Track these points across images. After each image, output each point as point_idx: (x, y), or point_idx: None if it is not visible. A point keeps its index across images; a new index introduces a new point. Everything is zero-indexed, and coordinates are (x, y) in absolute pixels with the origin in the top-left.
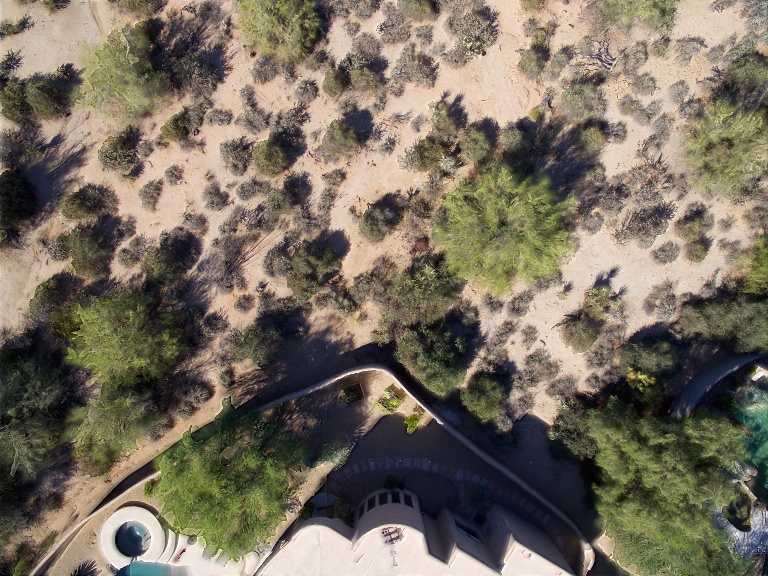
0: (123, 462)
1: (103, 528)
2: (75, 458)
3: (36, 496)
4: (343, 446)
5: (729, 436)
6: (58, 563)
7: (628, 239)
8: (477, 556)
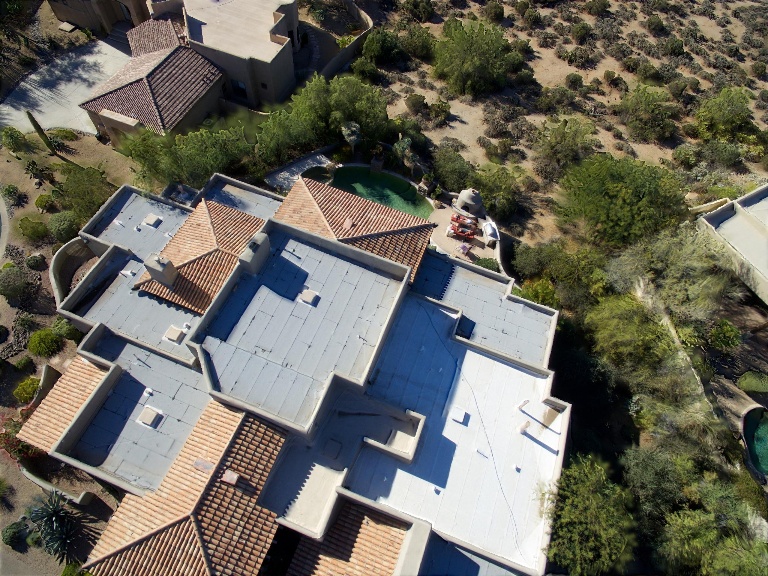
0: None
1: None
2: None
3: None
4: None
5: None
6: None
7: None
8: None
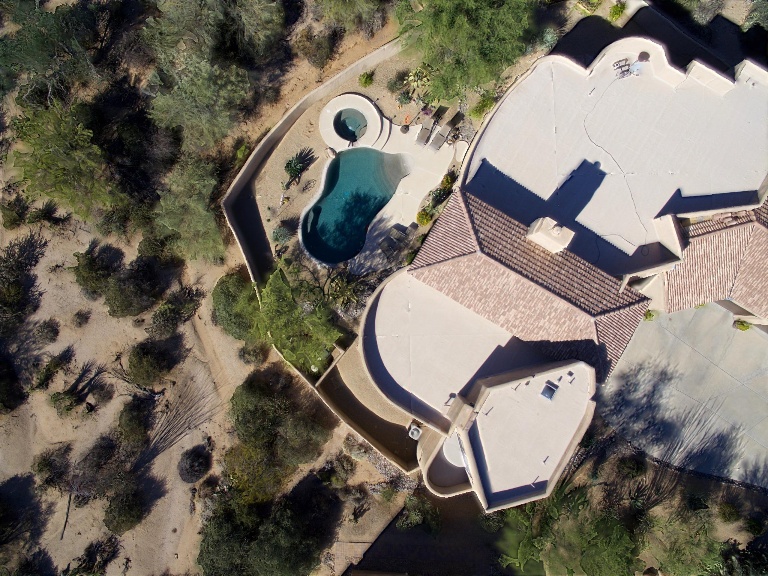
0: (334, 61)
1: (321, 113)
2: (293, 48)
3: (252, 91)
4: None
5: None
6: (275, 152)
7: None
8: None
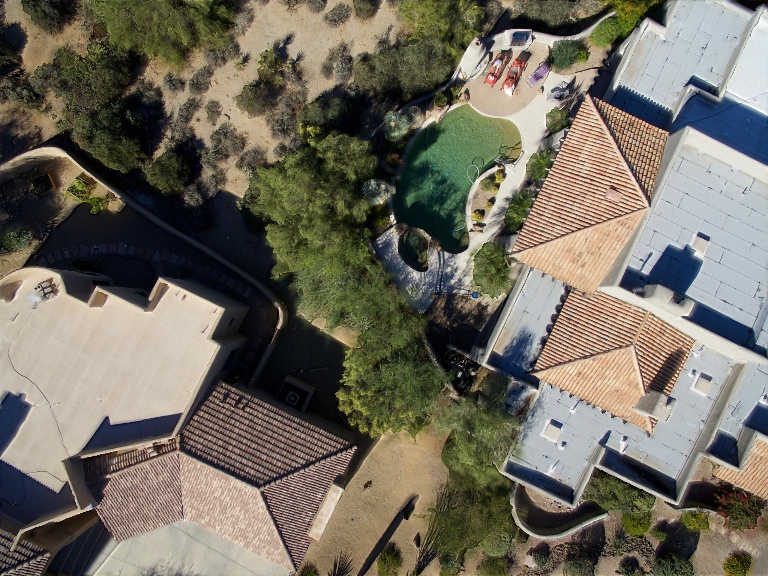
0: None
1: None
2: None
3: None
4: (24, 230)
5: (353, 148)
6: None
7: (299, 4)
8: (120, 295)
